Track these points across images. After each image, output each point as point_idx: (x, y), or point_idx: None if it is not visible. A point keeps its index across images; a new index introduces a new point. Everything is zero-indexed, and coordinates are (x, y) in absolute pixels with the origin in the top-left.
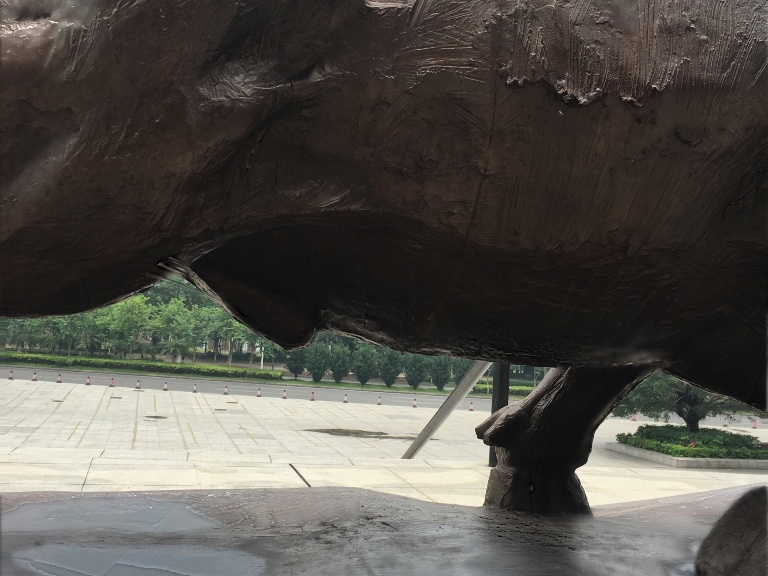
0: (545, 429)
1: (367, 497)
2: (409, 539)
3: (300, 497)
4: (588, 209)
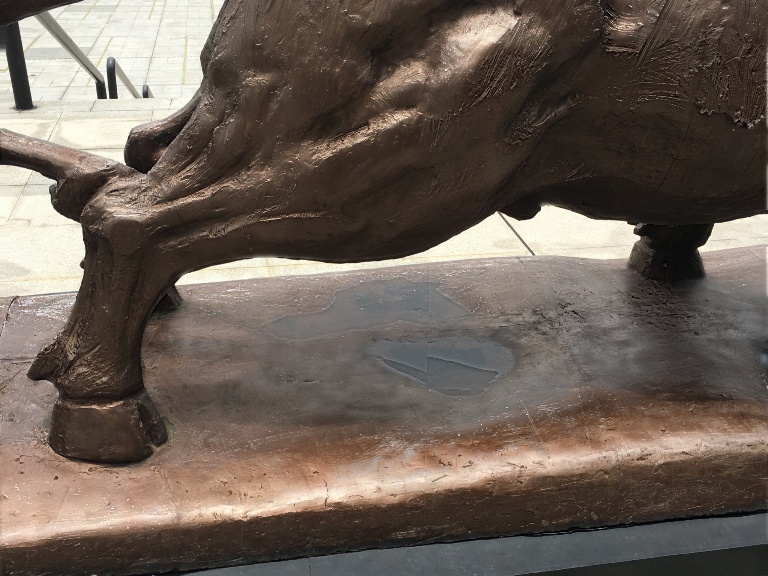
0: (680, 226)
1: (555, 280)
2: (595, 331)
3: (509, 278)
4: (742, 176)
